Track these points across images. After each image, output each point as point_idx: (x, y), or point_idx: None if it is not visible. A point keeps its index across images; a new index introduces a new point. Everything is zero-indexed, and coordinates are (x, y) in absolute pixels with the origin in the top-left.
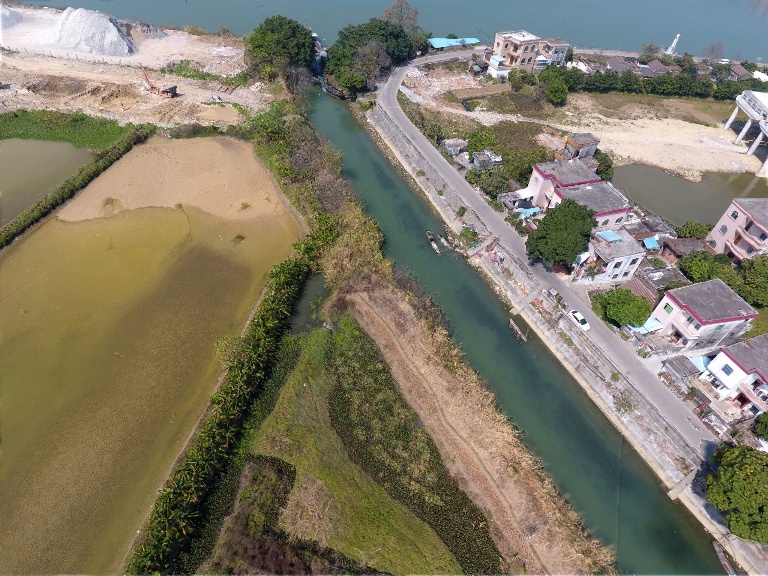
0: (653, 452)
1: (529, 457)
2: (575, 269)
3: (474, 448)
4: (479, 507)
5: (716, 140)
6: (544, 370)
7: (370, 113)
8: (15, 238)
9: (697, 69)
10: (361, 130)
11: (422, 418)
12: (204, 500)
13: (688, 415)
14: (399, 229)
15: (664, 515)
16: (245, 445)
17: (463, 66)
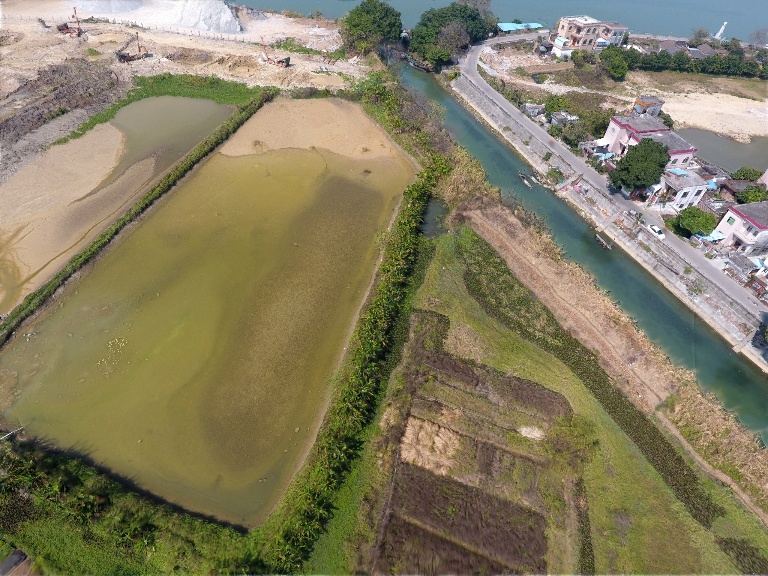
0: (720, 321)
1: None
2: (649, 197)
3: (581, 311)
4: (589, 348)
5: (763, 111)
6: (627, 269)
7: (455, 83)
8: (194, 166)
9: (744, 52)
10: (448, 96)
11: (537, 294)
12: (387, 332)
13: (748, 296)
14: (495, 170)
15: (730, 362)
16: (408, 302)
17: (529, 47)
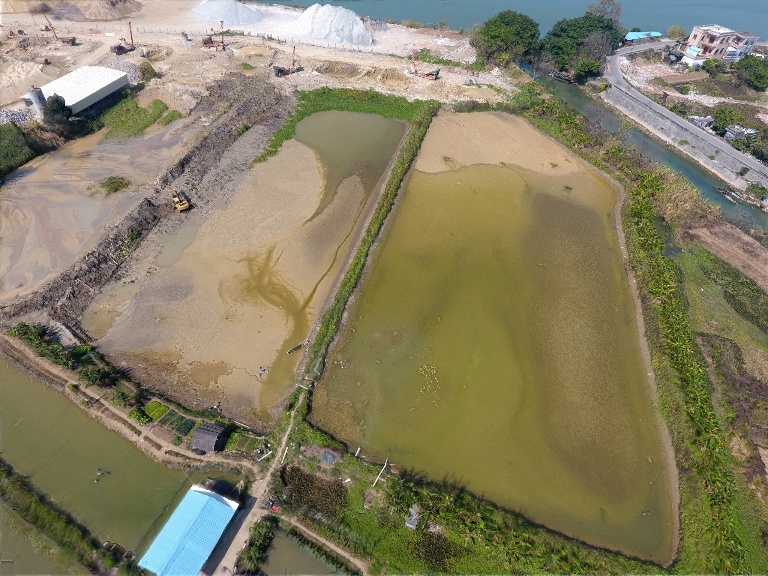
0: None
1: None
2: None
3: None
4: None
5: None
6: None
7: (605, 94)
8: (400, 183)
9: None
10: (603, 108)
11: None
12: None
13: None
14: None
15: None
16: None
17: (658, 56)
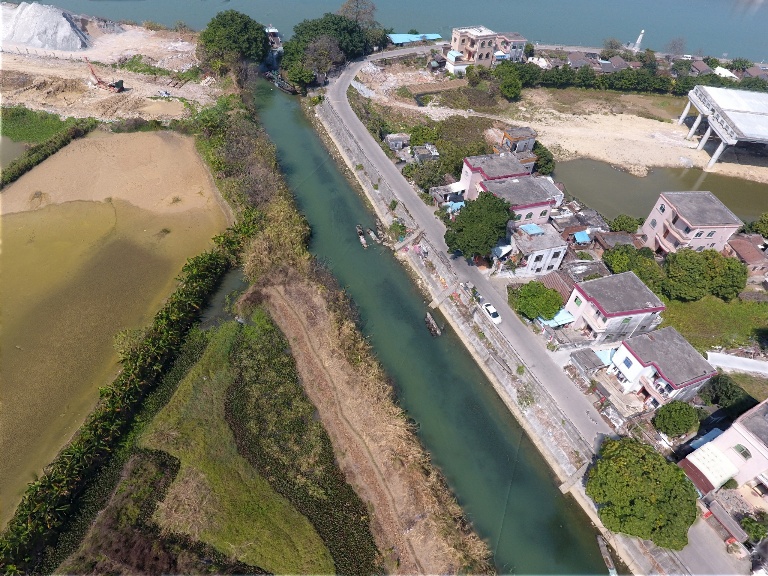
0: (550, 445)
1: (418, 450)
2: (495, 262)
3: (366, 441)
4: (363, 501)
5: (668, 135)
6: (454, 364)
7: (319, 108)
8: None
9: (657, 65)
10: (308, 125)
11: (320, 411)
12: (80, 494)
13: (587, 408)
14: (330, 223)
15: (553, 509)
16: (132, 438)
17: (421, 61)
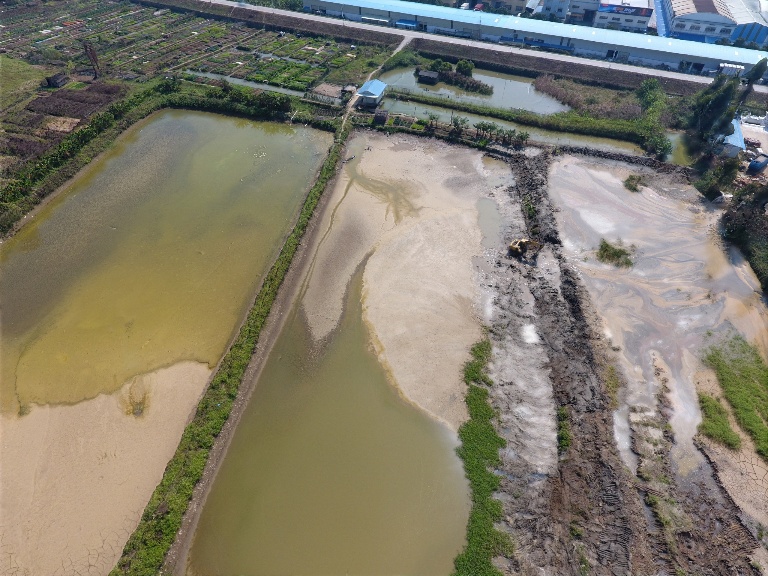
0: None
1: None
2: None
3: None
4: None
5: None
6: None
7: None
8: None
9: None
10: None
11: None
12: None
13: None
14: None
15: None
16: None
17: None
